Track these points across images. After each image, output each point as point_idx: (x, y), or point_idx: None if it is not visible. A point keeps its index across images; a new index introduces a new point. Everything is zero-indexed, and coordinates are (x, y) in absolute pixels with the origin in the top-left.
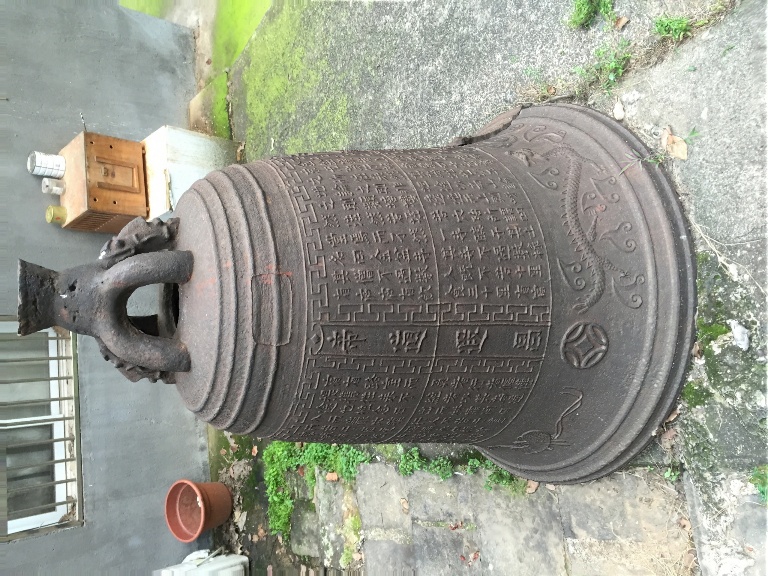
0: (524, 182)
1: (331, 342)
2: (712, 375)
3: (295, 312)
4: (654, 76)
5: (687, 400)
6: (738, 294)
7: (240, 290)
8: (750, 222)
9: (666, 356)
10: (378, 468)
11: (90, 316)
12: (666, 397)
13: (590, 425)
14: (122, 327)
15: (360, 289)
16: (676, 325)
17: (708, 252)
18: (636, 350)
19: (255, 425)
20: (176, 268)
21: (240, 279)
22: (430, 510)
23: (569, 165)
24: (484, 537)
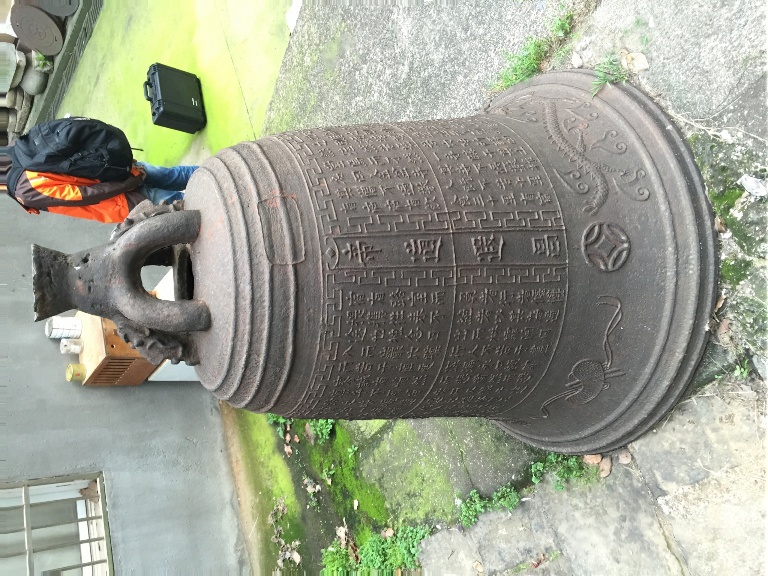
0: (505, 122)
1: (347, 255)
2: (743, 241)
3: (305, 229)
4: (598, 17)
5: (728, 281)
6: (738, 153)
7: (248, 218)
8: (725, 87)
9: (691, 238)
10: (441, 537)
11: (105, 284)
12: (706, 283)
13: (639, 339)
14: (138, 292)
15: (366, 202)
16: (690, 203)
17: (697, 133)
18: (659, 241)
19: (286, 371)
20: (184, 221)
21: (247, 208)
22: (506, 555)
23: (544, 106)
24: (571, 551)
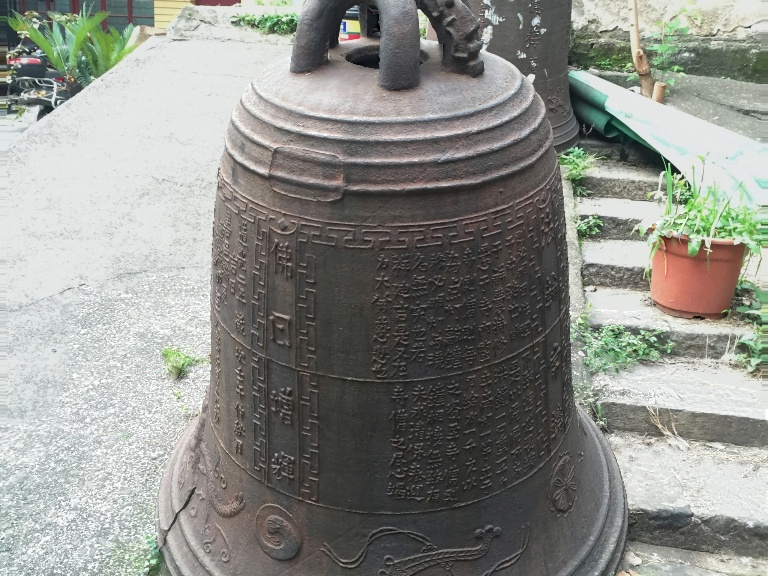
0: None
1: None
2: None
3: None
4: None
5: None
6: None
7: None
8: None
9: None
10: None
11: None
12: None
13: None
14: None
15: None
16: None
17: None
18: None
19: None
20: None
21: None
22: None
23: None
24: None
